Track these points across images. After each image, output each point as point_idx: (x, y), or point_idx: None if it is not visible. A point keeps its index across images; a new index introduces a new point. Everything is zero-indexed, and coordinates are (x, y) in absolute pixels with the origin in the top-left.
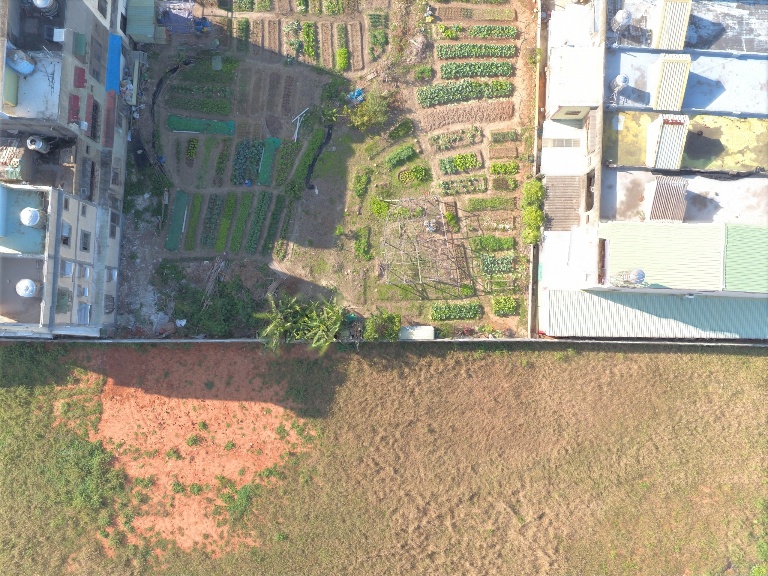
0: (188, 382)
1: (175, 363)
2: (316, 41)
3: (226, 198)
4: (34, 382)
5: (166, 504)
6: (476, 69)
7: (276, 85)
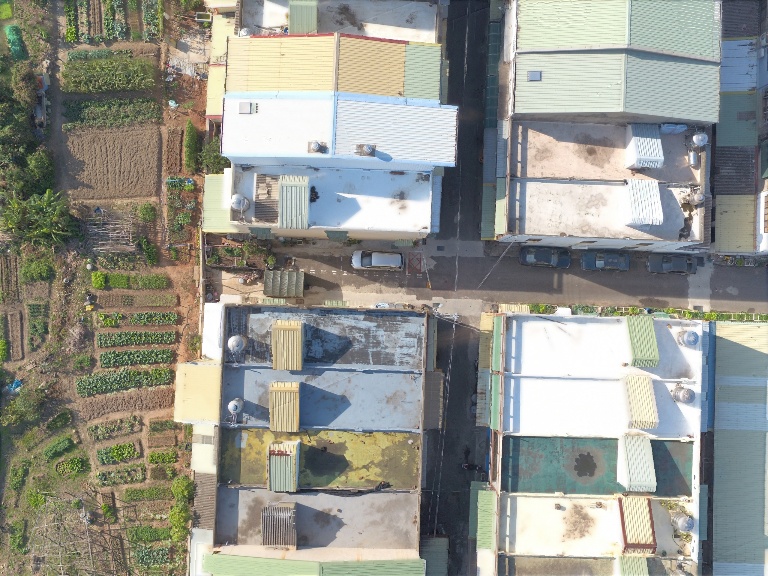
0: None
1: None
2: None
3: None
4: None
5: None
6: (135, 358)
7: None
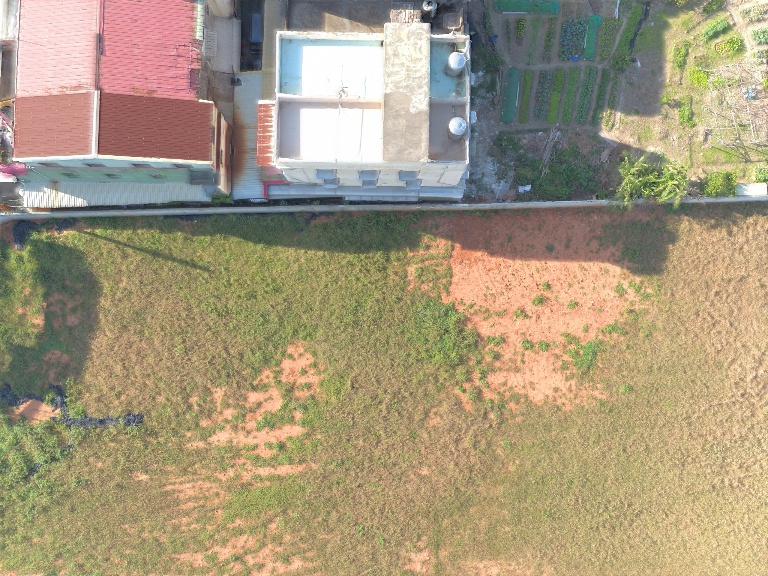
0: (530, 246)
1: (517, 228)
2: None
3: (555, 73)
4: (389, 249)
5: (516, 360)
6: None
7: None
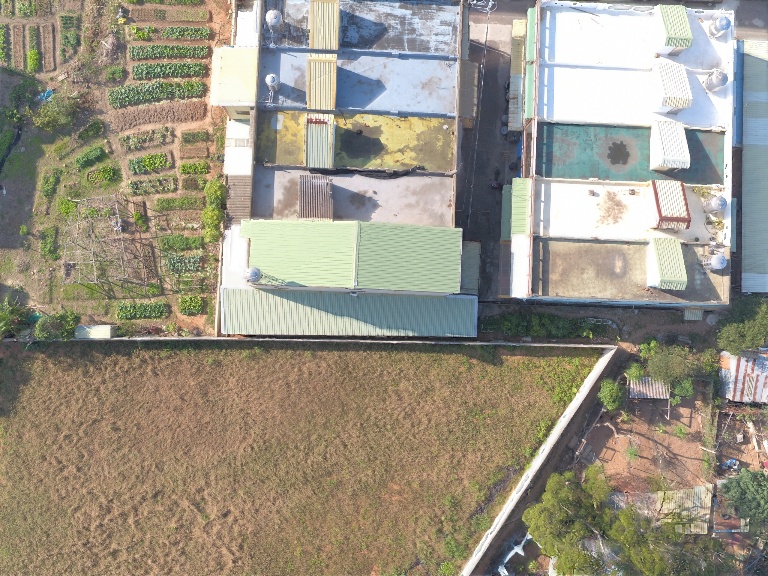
0: None
1: None
2: (8, 43)
3: None
4: None
5: None
6: (167, 70)
7: None
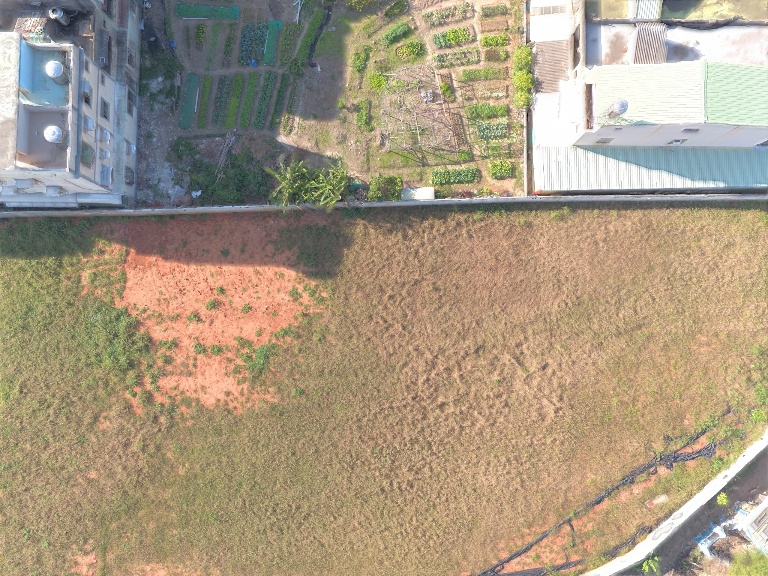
0: (205, 251)
1: (192, 233)
2: None
3: (235, 79)
4: (62, 254)
5: (189, 365)
6: None
7: None
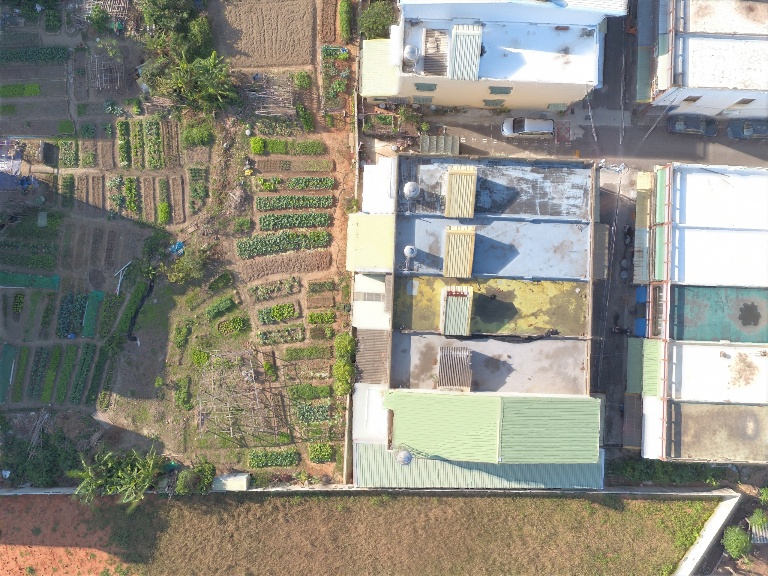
0: (16, 529)
1: (3, 511)
2: (139, 196)
3: (51, 351)
4: None
5: None
6: (294, 221)
7: (99, 240)
